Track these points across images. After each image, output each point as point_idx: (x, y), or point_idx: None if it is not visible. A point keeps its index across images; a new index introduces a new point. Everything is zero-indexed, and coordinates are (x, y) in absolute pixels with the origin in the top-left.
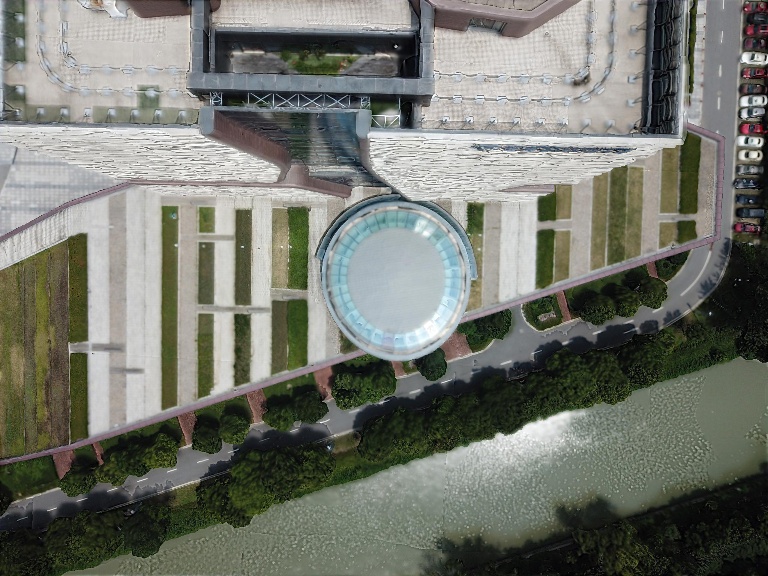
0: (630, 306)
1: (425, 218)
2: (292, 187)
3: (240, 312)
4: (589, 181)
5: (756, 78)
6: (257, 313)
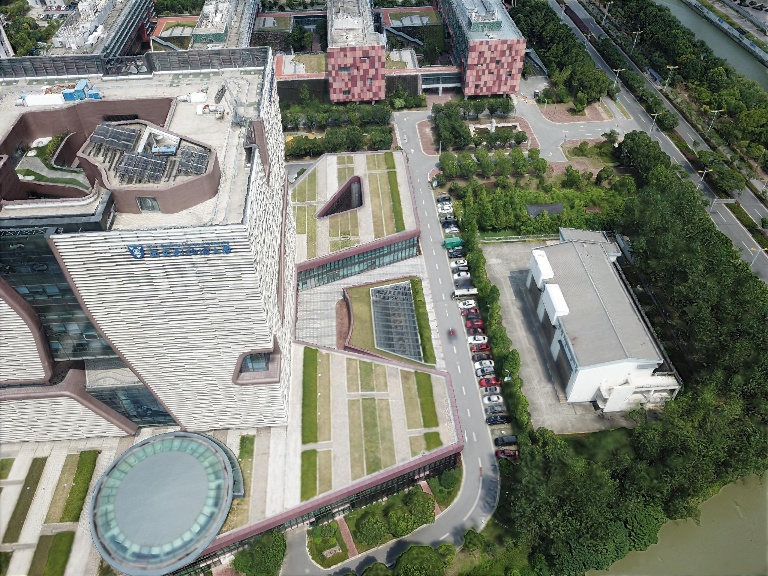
0: (396, 513)
1: (197, 443)
2: (67, 396)
3: (4, 550)
4: (345, 412)
5: (482, 351)
6: (21, 550)
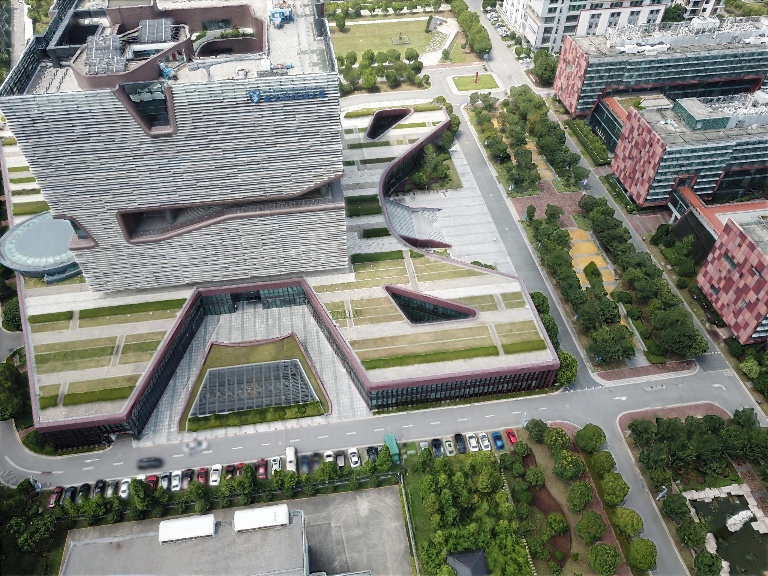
0: None
1: None
2: None
3: None
4: (105, 335)
5: None
6: None
